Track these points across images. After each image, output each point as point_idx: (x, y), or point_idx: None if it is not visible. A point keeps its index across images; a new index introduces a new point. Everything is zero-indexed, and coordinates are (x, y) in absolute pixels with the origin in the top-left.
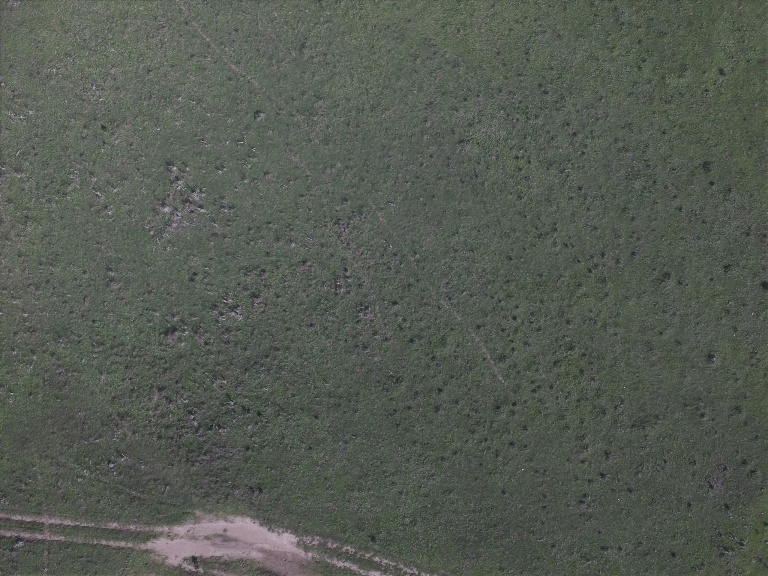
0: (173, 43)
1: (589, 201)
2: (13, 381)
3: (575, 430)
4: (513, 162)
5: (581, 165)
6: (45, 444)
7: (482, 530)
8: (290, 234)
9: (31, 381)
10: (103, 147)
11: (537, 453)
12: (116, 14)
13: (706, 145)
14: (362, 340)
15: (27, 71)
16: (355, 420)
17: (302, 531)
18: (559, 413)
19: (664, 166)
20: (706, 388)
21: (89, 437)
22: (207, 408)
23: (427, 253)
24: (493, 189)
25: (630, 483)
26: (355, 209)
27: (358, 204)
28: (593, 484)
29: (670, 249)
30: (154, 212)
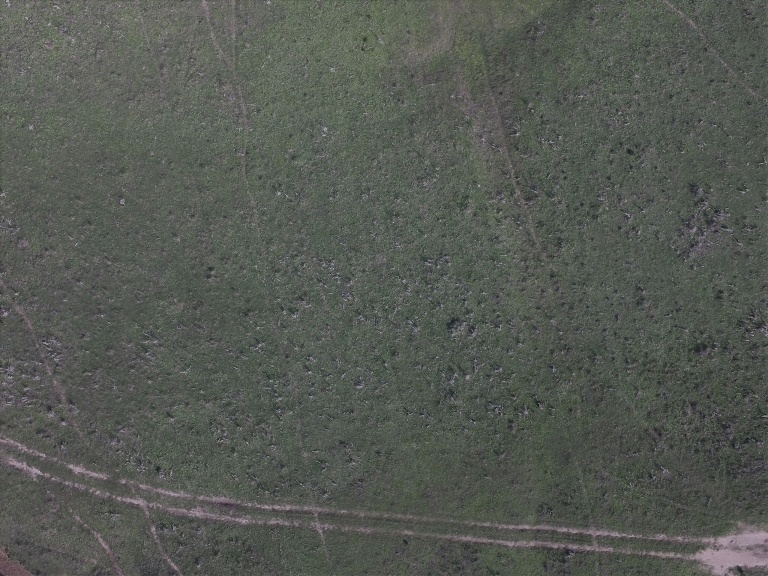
0: (693, 69)
1: None
2: (552, 397)
3: None
4: None
5: None
6: (587, 458)
7: None
8: None
9: (570, 397)
10: (630, 170)
11: None
12: (638, 42)
13: None
14: None
15: (554, 98)
16: None
17: None
18: None
19: None
20: None
21: (629, 451)
22: (740, 421)
23: None
24: None
25: None
26: None
27: None
28: None
29: None
30: (679, 232)
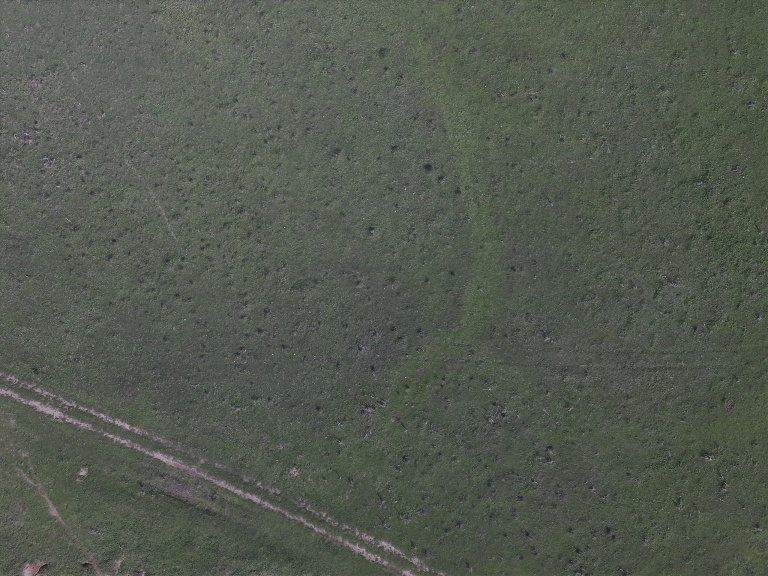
0: None
1: (270, 77)
2: None
3: (238, 287)
4: (202, 35)
5: (266, 43)
6: None
7: (141, 372)
8: None
9: None
10: None
11: (200, 306)
12: None
13: (384, 33)
14: (45, 189)
15: None
16: (31, 261)
17: None
18: (224, 271)
19: (343, 49)
20: (364, 258)
21: None
22: None
23: (114, 113)
24: (181, 58)
25: (285, 340)
26: (50, 67)
27: (53, 62)
28: (249, 338)
29: (343, 127)
30: None
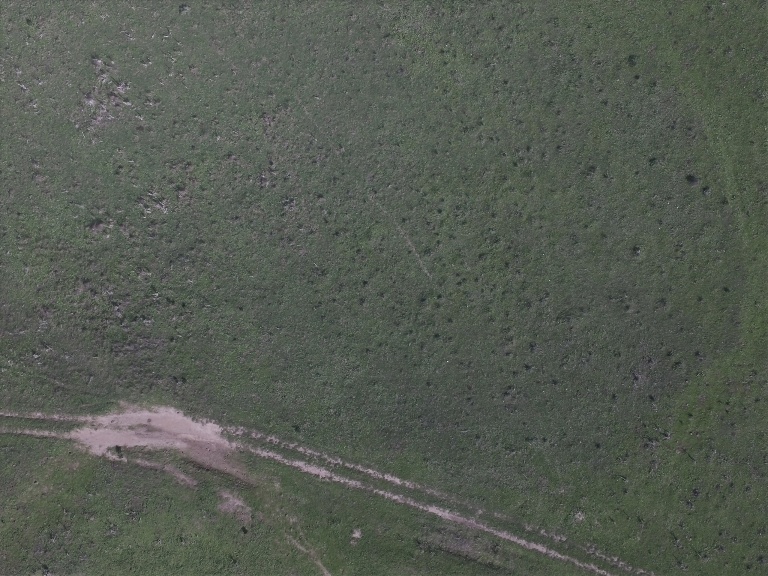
0: None
1: (515, 95)
2: None
3: (500, 322)
4: (439, 56)
5: (507, 59)
6: None
7: (407, 421)
8: (215, 128)
9: None
10: (28, 41)
11: (462, 345)
12: None
13: (631, 39)
14: (287, 233)
15: None
16: (280, 312)
17: (226, 421)
18: (484, 306)
19: (589, 60)
20: (631, 281)
21: (14, 328)
22: (132, 300)
23: (353, 147)
24: (419, 83)
25: (555, 375)
26: (281, 103)
27: (284, 98)
28: (518, 376)
29: (596, 143)
30: (79, 106)
